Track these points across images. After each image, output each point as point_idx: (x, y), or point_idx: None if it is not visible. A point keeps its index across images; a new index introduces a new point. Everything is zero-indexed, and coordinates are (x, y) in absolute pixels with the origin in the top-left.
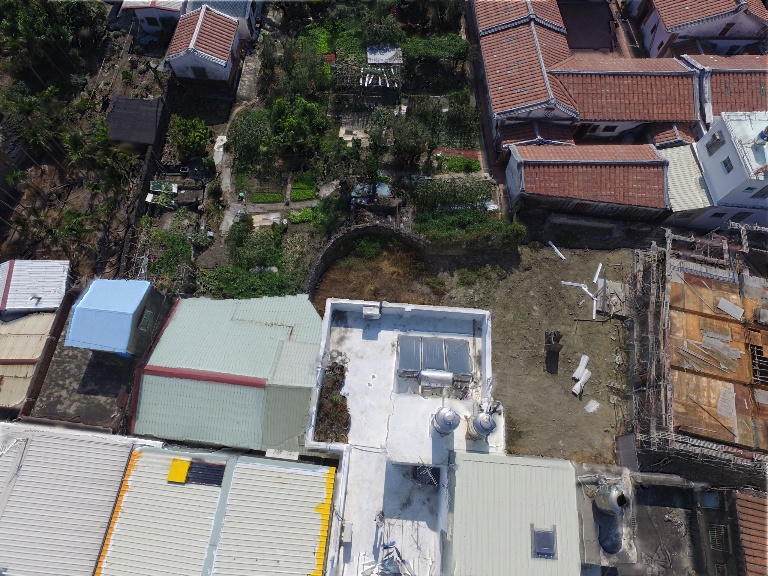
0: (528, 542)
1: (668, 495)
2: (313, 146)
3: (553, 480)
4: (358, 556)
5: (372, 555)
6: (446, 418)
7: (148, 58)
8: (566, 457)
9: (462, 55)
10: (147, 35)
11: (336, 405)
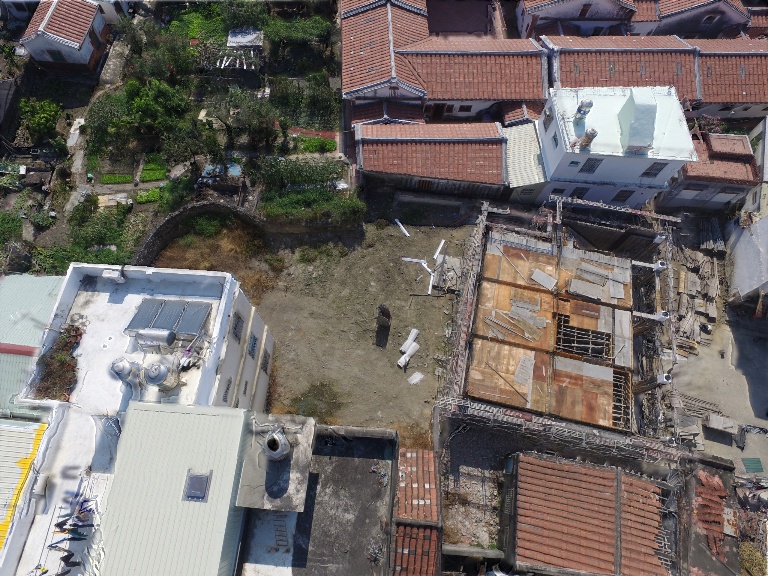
0: (181, 486)
1: (374, 447)
2: (161, 127)
3: (220, 428)
4: (54, 509)
5: (69, 508)
6: (114, 368)
7: (16, 43)
8: None
9: (324, 37)
10: None
11: (62, 365)
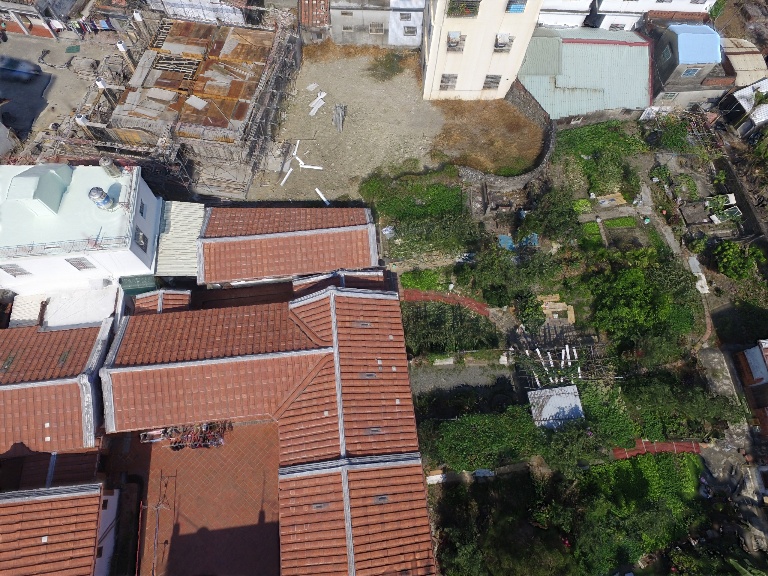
0: None
1: None
2: None
3: None
4: None
5: None
6: None
7: None
8: (337, 60)
9: None
10: None
11: None
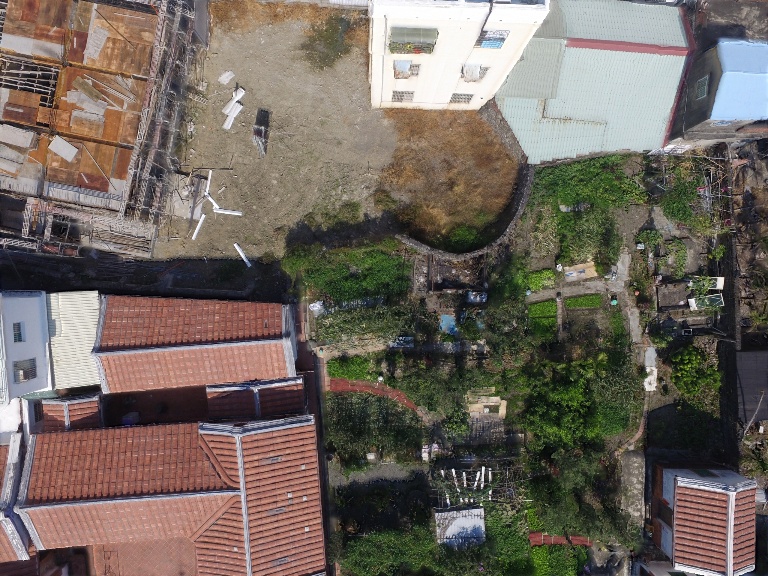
0: None
1: None
2: None
3: None
4: None
5: None
6: None
7: None
8: (259, 28)
9: (351, 538)
10: None
11: None
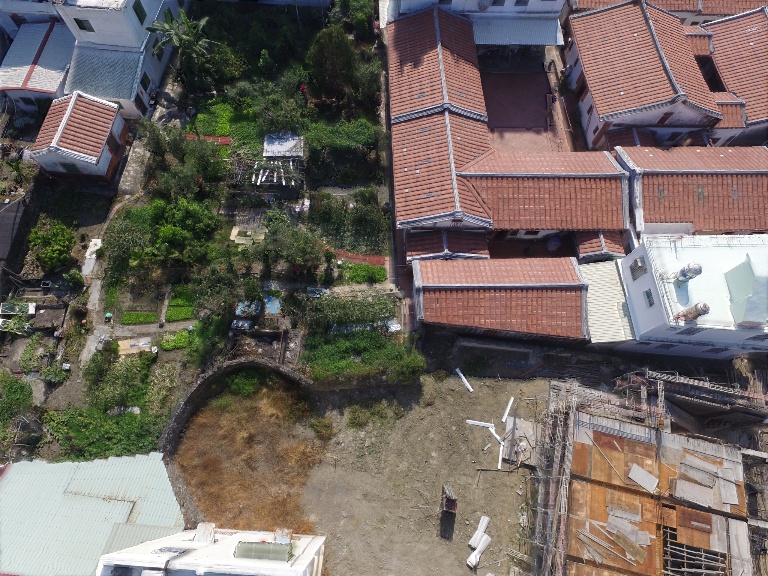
0: None
1: None
2: (190, 260)
3: None
4: None
5: None
6: None
7: (23, 143)
8: None
9: (371, 145)
10: (26, 114)
11: None
